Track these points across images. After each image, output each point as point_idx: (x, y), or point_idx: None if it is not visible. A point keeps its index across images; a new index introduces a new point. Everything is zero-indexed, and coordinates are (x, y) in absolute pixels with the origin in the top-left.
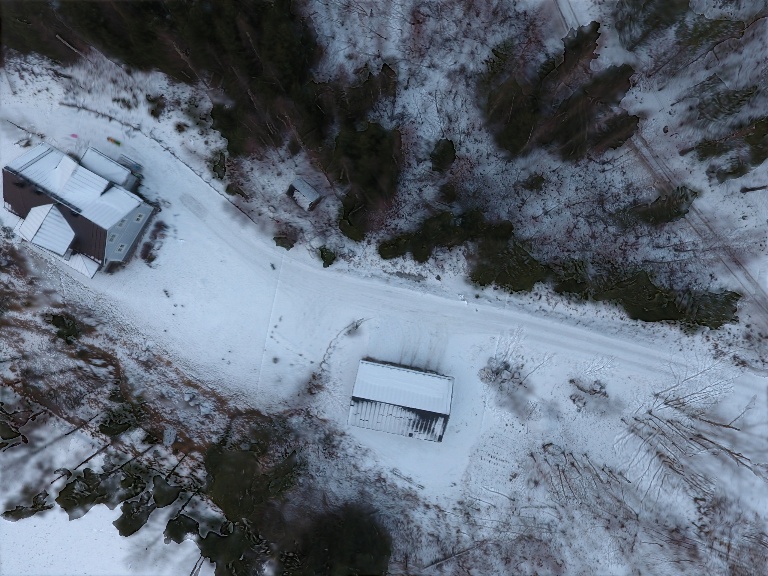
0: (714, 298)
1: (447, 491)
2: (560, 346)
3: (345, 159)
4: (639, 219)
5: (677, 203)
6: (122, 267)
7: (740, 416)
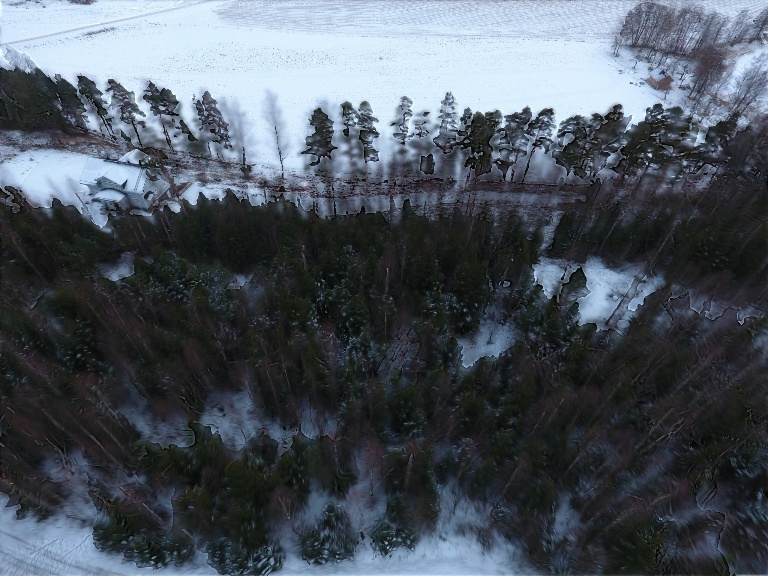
0: None
1: None
2: None
3: None
4: None
5: None
6: None
7: None
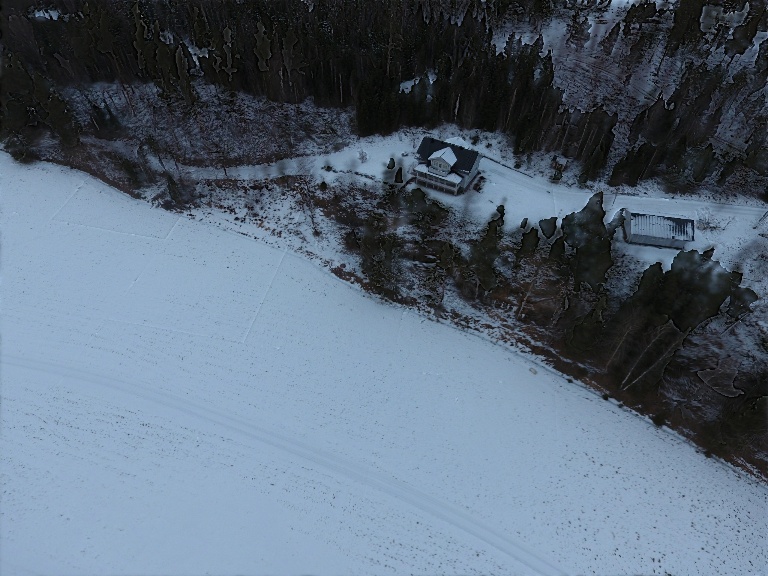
0: None
1: None
2: (736, 214)
3: (594, 125)
4: (742, 166)
5: (759, 129)
6: (462, 194)
7: None
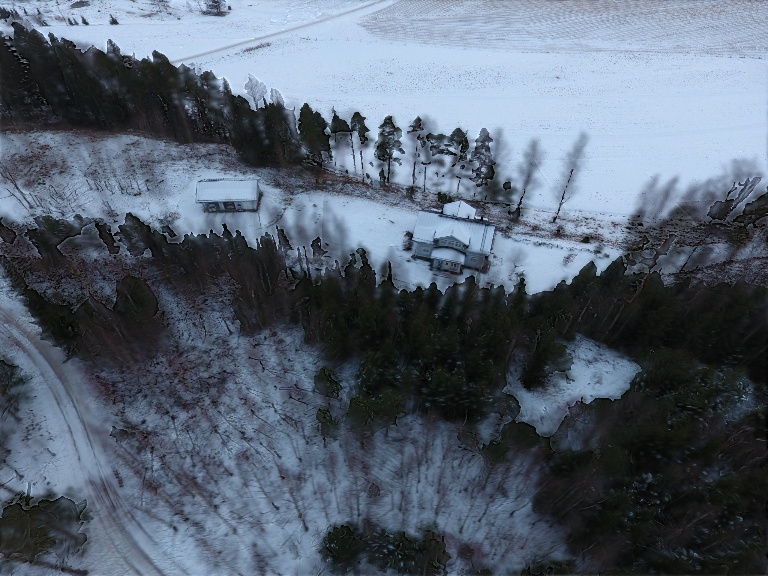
0: (2, 229)
1: (203, 173)
2: None
3: None
4: None
5: None
6: None
7: (3, 198)
